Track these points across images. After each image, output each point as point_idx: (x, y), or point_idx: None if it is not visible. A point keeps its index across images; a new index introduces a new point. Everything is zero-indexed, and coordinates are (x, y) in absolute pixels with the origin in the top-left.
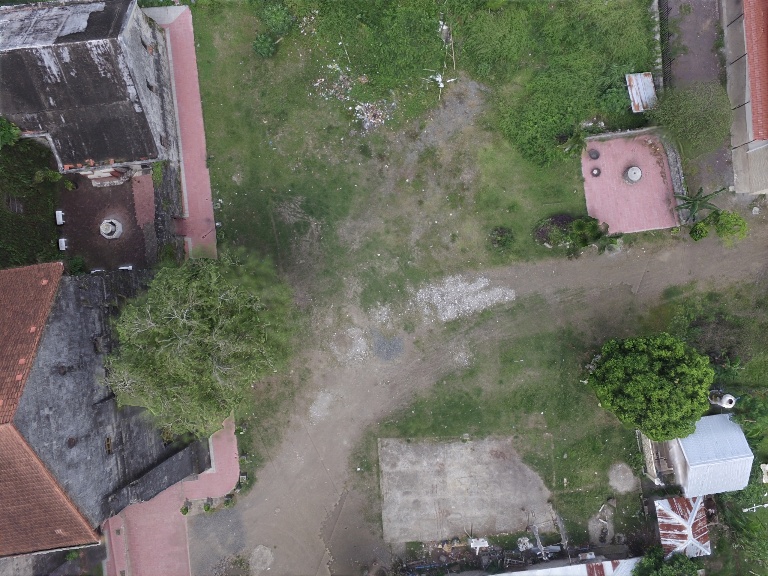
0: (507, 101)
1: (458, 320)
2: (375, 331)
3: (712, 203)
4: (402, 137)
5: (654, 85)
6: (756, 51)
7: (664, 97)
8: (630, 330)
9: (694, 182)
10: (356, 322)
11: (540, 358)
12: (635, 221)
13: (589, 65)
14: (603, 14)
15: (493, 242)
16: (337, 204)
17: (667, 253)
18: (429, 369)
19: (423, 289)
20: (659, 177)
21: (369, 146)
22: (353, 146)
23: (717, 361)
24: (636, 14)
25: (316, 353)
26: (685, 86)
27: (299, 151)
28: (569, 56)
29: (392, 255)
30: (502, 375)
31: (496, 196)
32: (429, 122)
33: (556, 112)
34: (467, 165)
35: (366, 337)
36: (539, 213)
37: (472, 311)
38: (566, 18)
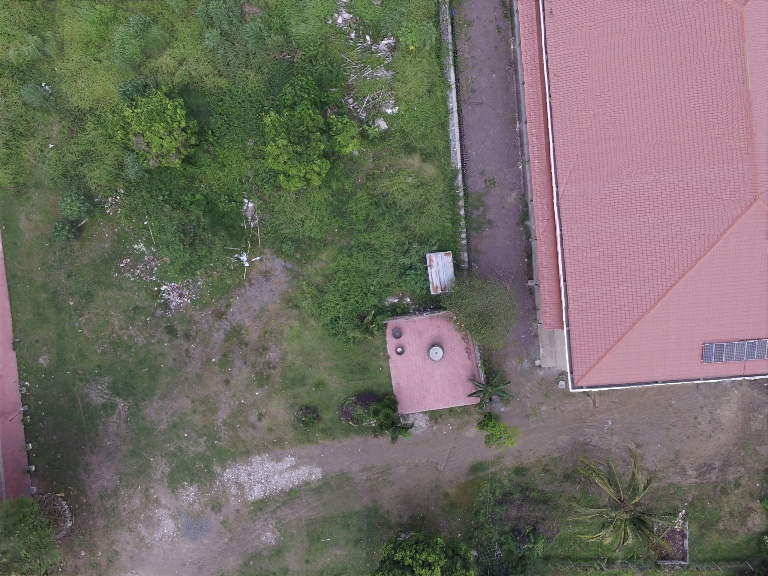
0: (311, 279)
1: (265, 500)
2: (182, 512)
3: (519, 377)
4: (208, 316)
5: (453, 266)
6: (543, 241)
7: (468, 273)
8: (436, 507)
9: (500, 356)
10: (164, 503)
11: (346, 537)
12: (440, 398)
13: (392, 243)
14: (404, 193)
15: (298, 422)
16: (143, 385)
17: (473, 429)
18: (236, 549)
19: (230, 469)
20: (464, 353)
21: (175, 326)
22: (159, 326)
23: (519, 541)
24: (438, 191)
25: (124, 535)
26: (490, 260)
27: (105, 333)
28: (372, 234)
29: (199, 435)
30: (308, 554)
31: (302, 374)
32: (235, 301)
33: (359, 291)
34: (273, 344)
35: (173, 518)
36: (345, 391)
37: (279, 490)
38: (370, 195)
